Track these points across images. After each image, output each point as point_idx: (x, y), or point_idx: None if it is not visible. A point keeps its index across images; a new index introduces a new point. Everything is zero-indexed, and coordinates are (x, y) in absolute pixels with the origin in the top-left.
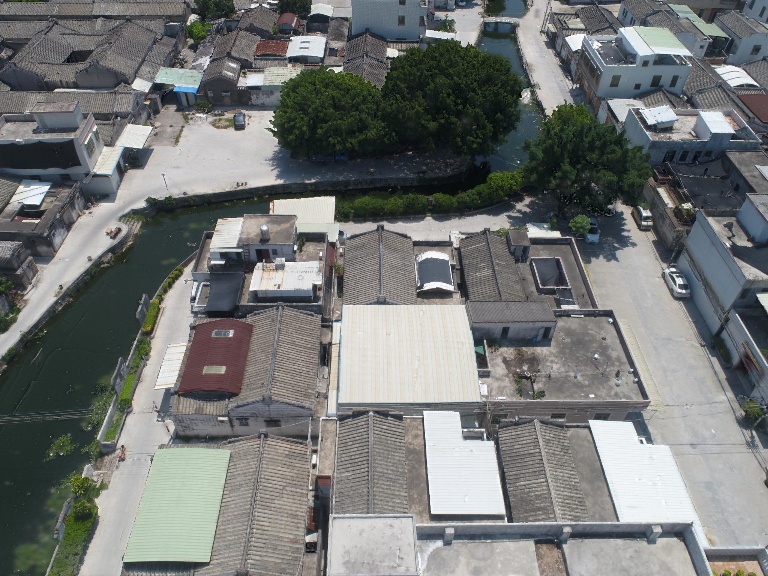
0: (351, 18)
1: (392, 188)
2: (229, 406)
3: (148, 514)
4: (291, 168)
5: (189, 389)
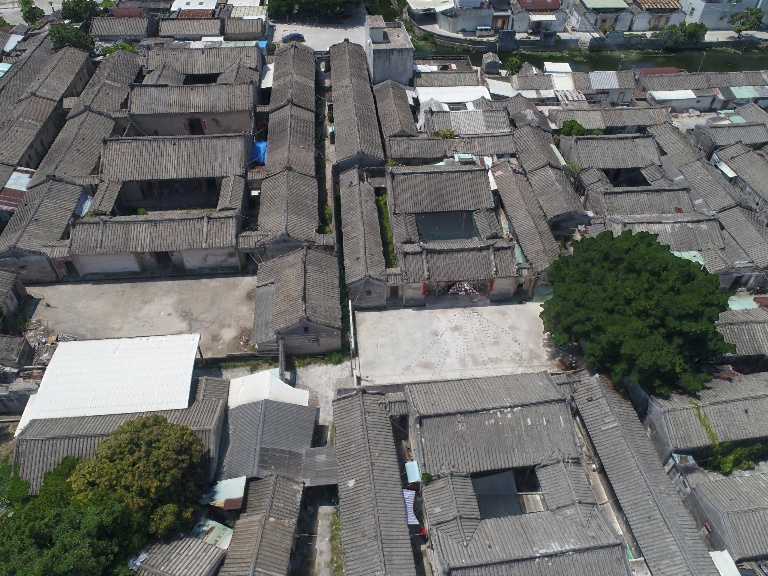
0: (116, 0)
1: (366, 6)
2: (560, 2)
3: (612, 5)
4: (355, 23)
5: (559, 4)
